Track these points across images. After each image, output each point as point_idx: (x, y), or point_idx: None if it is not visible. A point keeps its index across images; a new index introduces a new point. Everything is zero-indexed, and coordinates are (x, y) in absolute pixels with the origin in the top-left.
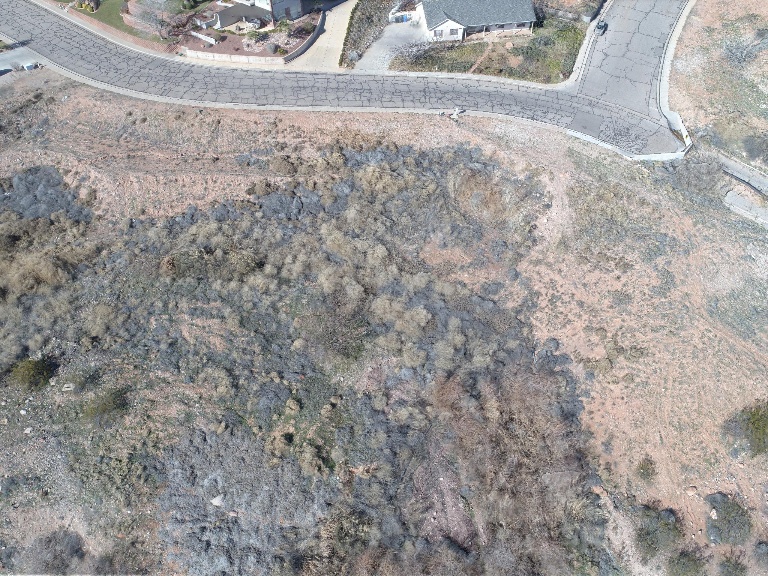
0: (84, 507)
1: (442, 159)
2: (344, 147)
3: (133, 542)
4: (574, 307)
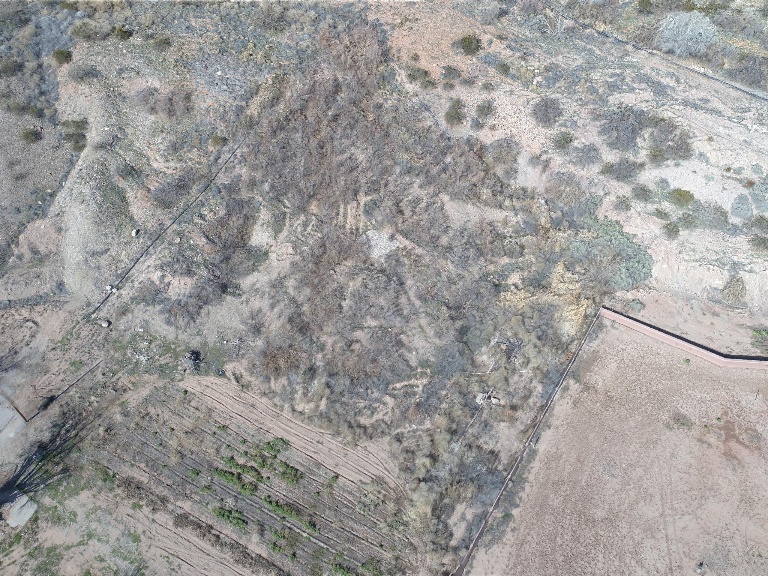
0: (157, 76)
1: None
2: None
3: (182, 85)
4: (388, 8)
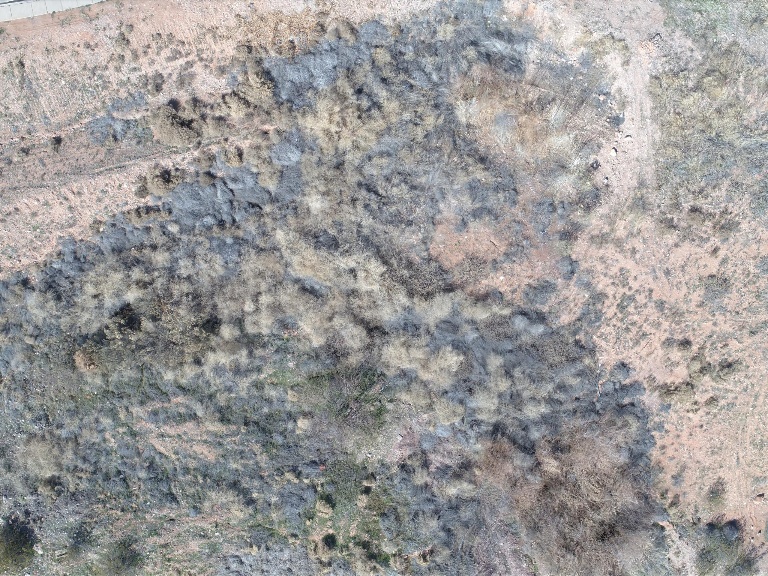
0: None
1: (435, 36)
2: (263, 56)
3: None
4: (651, 312)
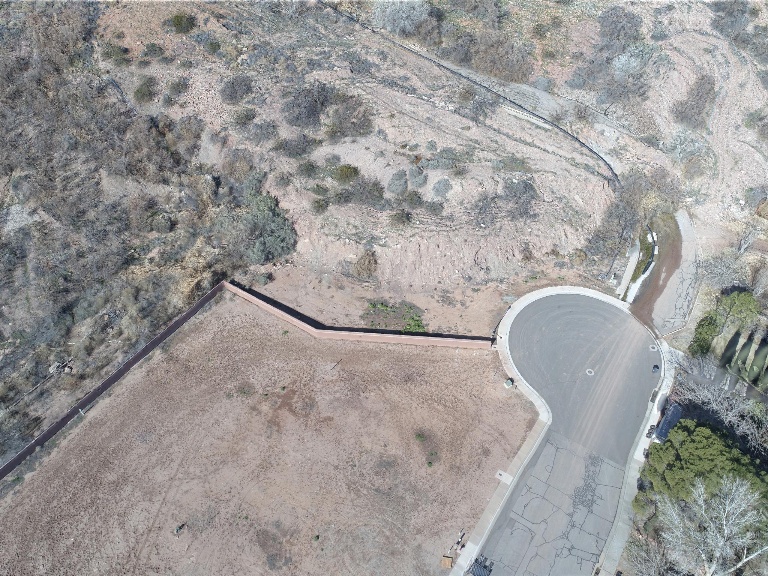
0: None
1: None
2: None
3: None
4: None
